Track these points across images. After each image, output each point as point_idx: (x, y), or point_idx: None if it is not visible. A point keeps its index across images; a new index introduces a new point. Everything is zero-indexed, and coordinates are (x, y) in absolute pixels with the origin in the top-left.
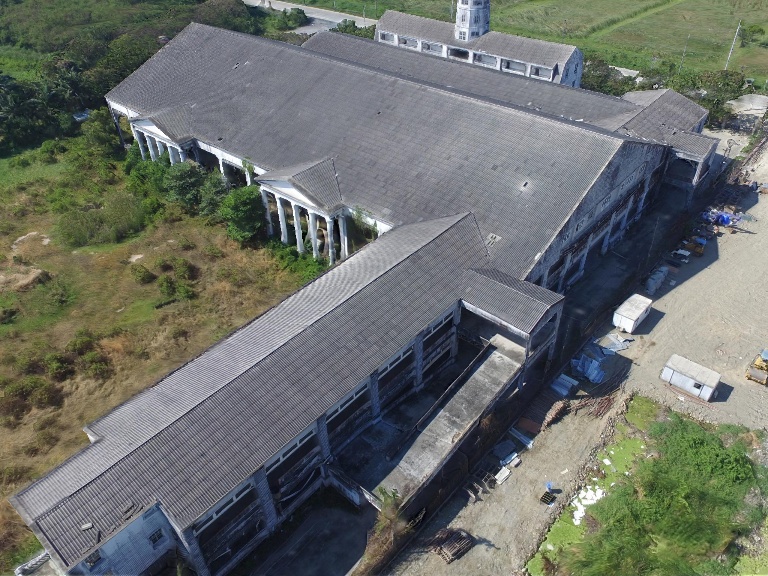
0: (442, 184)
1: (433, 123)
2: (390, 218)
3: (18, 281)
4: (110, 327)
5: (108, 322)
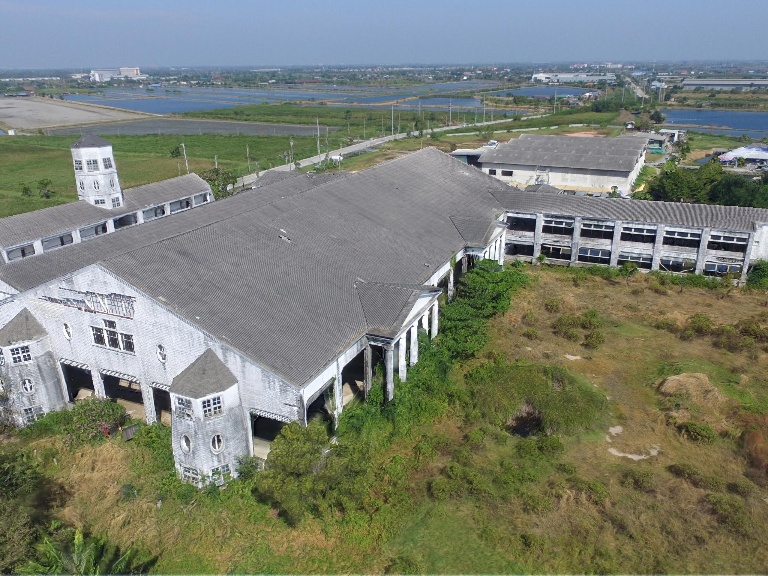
0: (469, 190)
1: (413, 177)
2: (501, 210)
3: (698, 386)
4: (669, 319)
5: (660, 338)
